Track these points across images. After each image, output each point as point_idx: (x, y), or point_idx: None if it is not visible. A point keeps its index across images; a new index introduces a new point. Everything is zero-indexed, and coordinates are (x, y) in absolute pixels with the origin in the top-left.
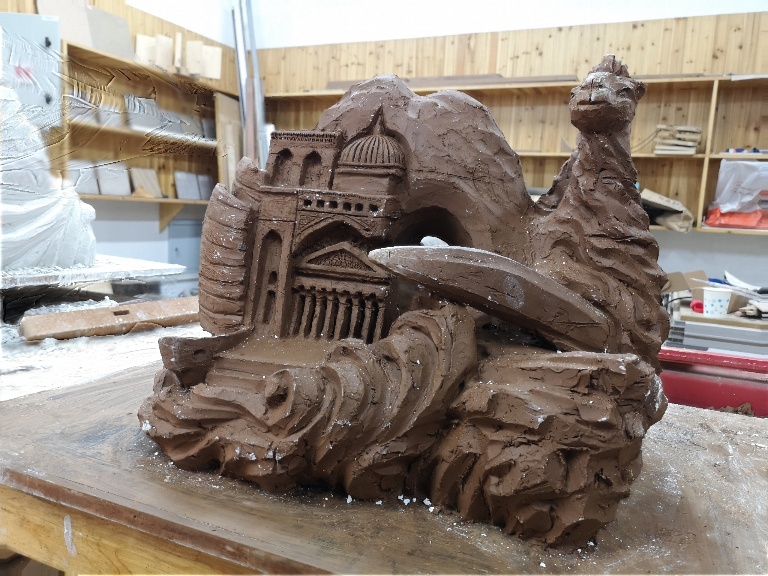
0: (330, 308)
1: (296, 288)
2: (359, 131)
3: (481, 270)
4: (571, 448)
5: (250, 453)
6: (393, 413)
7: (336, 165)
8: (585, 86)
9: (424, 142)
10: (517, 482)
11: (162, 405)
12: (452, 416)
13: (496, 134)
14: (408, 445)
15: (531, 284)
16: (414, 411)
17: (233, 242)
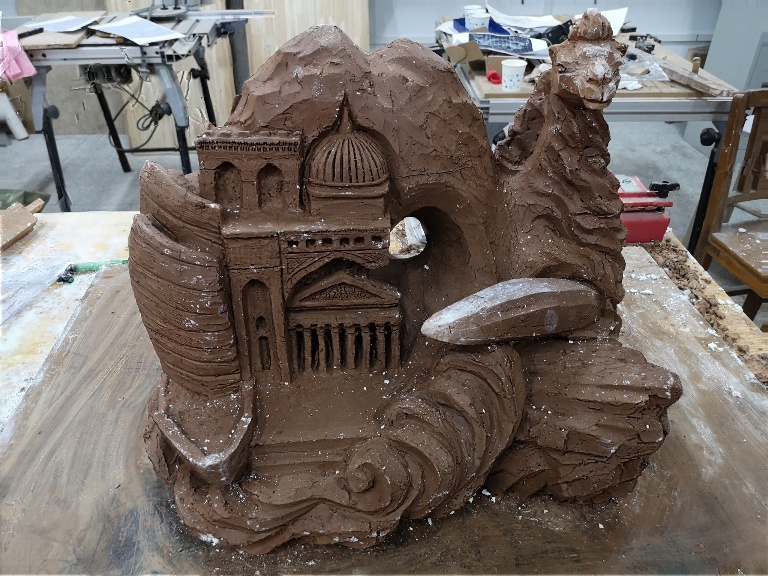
0: (337, 340)
1: (292, 328)
2: (321, 129)
3: (529, 315)
4: (631, 459)
5: (350, 538)
6: (476, 465)
7: (301, 176)
8: (595, 81)
9: (407, 139)
10: (590, 490)
11: (228, 522)
12: (515, 441)
13: (468, 102)
14: (484, 476)
15: (563, 308)
16: (489, 453)
17: (211, 308)
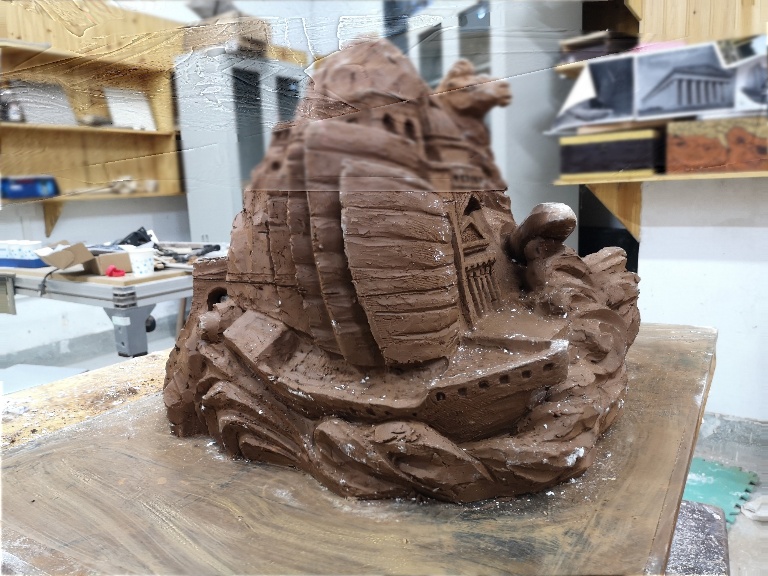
0: None
1: None
2: None
3: None
4: None
5: (621, 400)
6: None
7: None
8: None
9: None
10: None
11: (584, 417)
12: None
13: None
14: None
15: None
16: None
17: (449, 234)
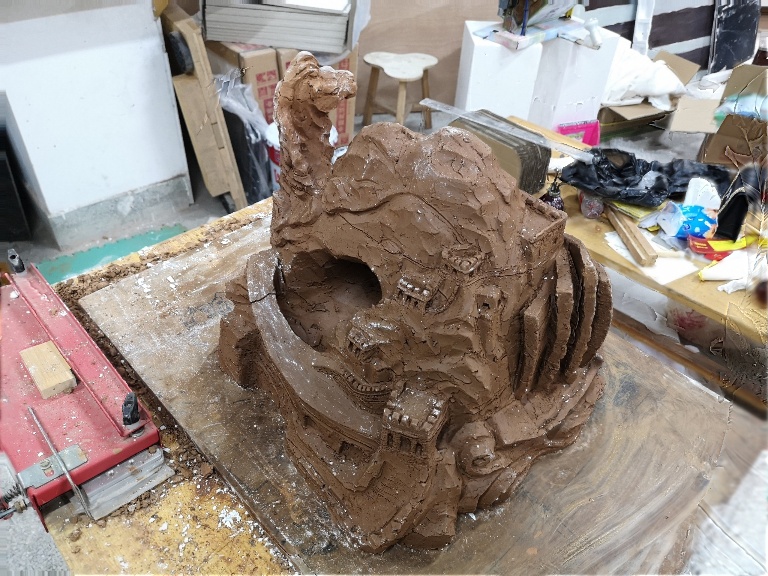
0: None
1: None
2: None
3: None
4: None
5: None
6: None
7: None
8: None
9: None
10: None
11: None
12: None
13: None
14: None
15: None
16: None
17: None
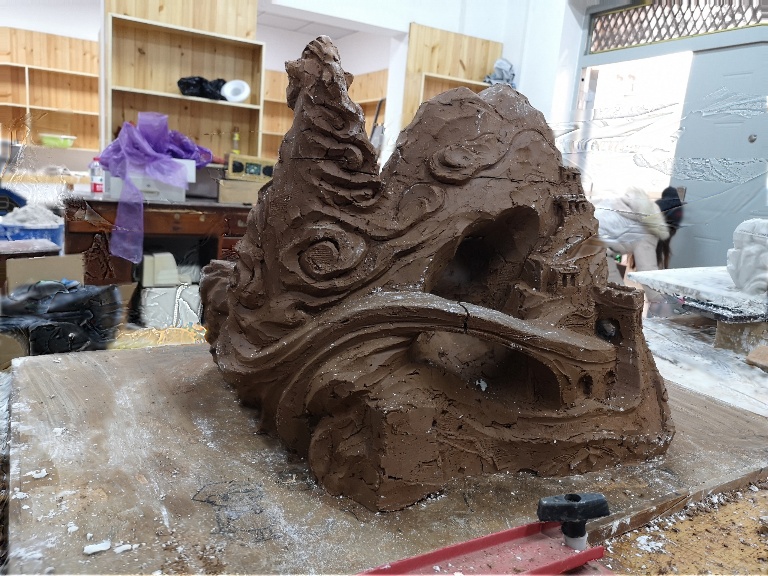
0: None
1: None
2: None
3: None
4: None
5: None
6: None
7: None
8: None
9: None
10: None
11: None
12: None
13: None
14: None
15: None
16: None
17: None
